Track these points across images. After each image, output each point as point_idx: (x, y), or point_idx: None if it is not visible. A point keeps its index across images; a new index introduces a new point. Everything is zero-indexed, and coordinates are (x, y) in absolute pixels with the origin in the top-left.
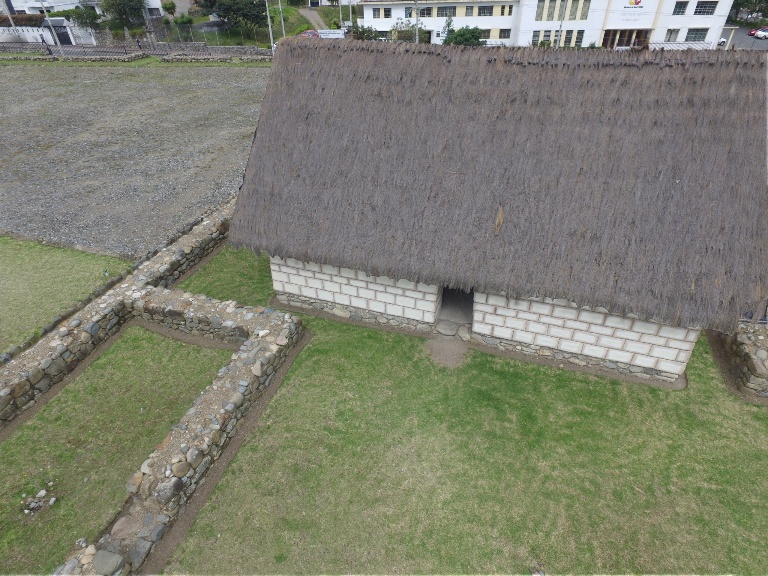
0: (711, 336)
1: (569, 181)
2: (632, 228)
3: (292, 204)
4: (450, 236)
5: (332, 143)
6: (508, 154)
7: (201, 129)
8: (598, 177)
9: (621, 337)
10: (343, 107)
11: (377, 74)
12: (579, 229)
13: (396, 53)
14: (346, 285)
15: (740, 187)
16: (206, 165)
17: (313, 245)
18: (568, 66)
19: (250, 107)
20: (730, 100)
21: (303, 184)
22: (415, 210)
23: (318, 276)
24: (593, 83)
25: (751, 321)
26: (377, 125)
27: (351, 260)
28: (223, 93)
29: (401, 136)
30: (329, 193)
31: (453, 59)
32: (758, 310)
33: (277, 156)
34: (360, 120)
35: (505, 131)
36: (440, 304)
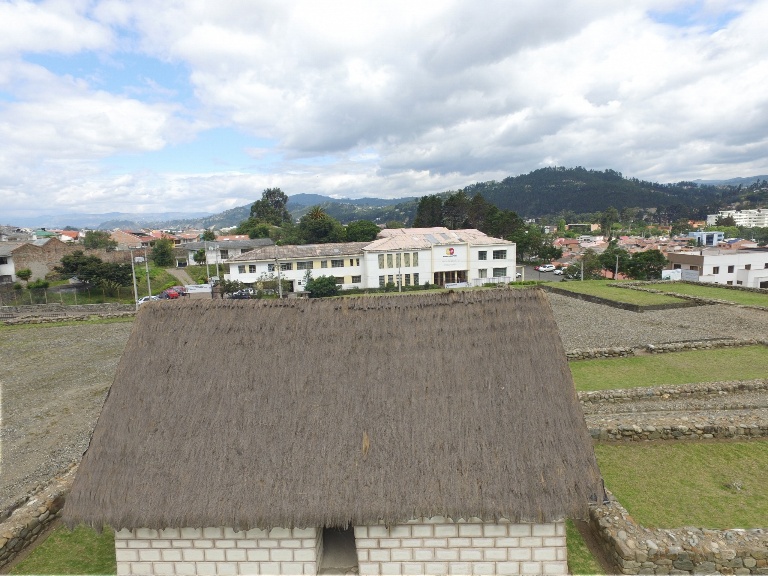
0: (580, 526)
1: (419, 399)
2: (480, 434)
3: (147, 462)
4: (321, 469)
5: (194, 392)
6: (363, 382)
7: (43, 391)
8: (442, 393)
9: (503, 546)
10: (206, 357)
11: (238, 326)
12: (437, 442)
13: (255, 308)
14: (211, 549)
15: (548, 387)
16: (43, 431)
17: (170, 506)
18: (399, 308)
19: (106, 362)
20: (519, 323)
21: (161, 438)
22: (283, 448)
23: (176, 544)
24: (420, 319)
25: (597, 503)
26: (240, 370)
27: (216, 516)
28: (75, 351)
29: (264, 377)
30: (190, 443)
31: (306, 309)
32: (598, 491)
33: (132, 412)
34: (223, 367)
35: (358, 363)
36: (321, 549)
